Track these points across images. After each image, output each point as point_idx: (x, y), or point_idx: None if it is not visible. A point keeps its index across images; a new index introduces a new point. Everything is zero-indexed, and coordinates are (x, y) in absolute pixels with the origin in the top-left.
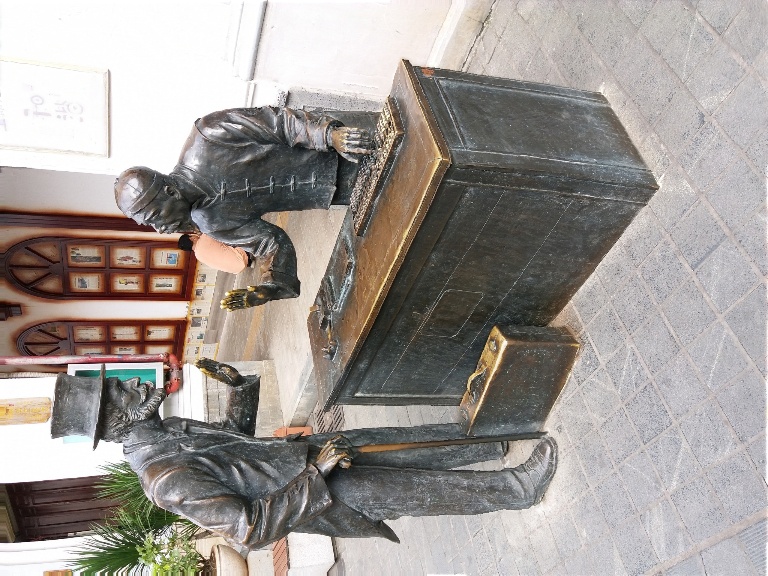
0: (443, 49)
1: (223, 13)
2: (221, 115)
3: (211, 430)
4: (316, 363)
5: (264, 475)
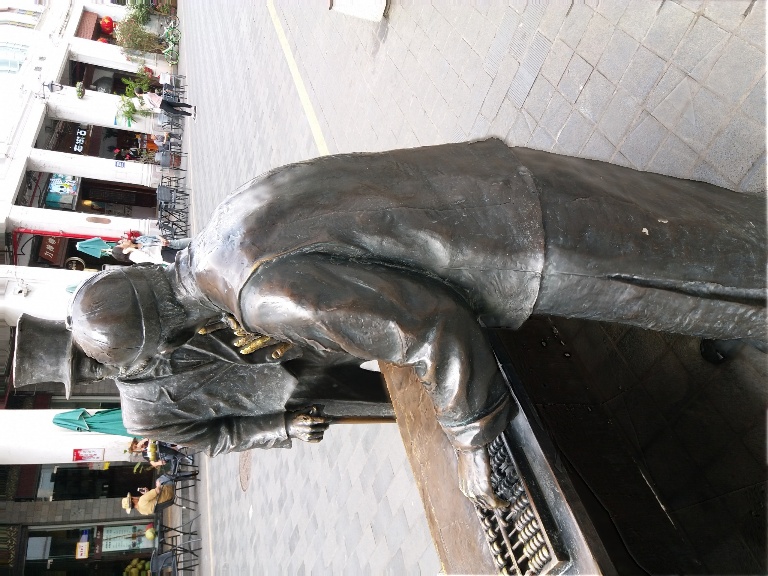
0: None
1: None
2: (297, 321)
3: (202, 350)
4: None
5: (240, 410)
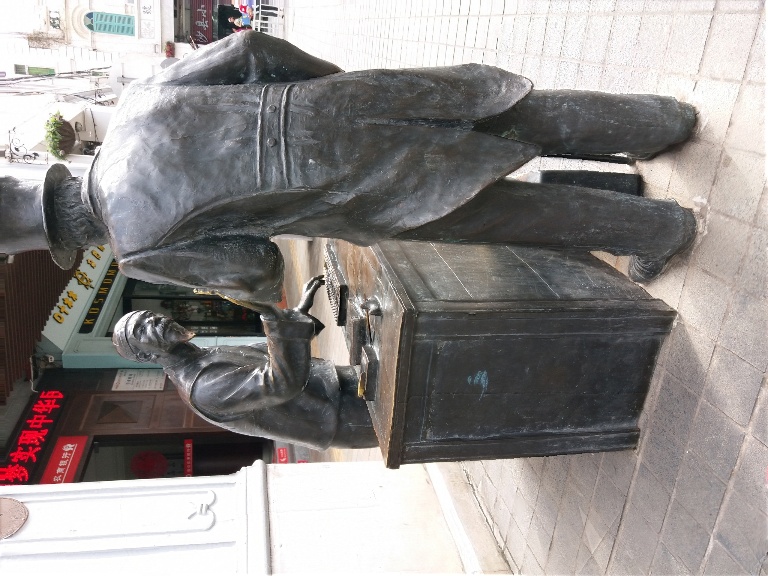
0: (456, 517)
1: (229, 552)
2: None
3: None
4: (391, 378)
5: None
